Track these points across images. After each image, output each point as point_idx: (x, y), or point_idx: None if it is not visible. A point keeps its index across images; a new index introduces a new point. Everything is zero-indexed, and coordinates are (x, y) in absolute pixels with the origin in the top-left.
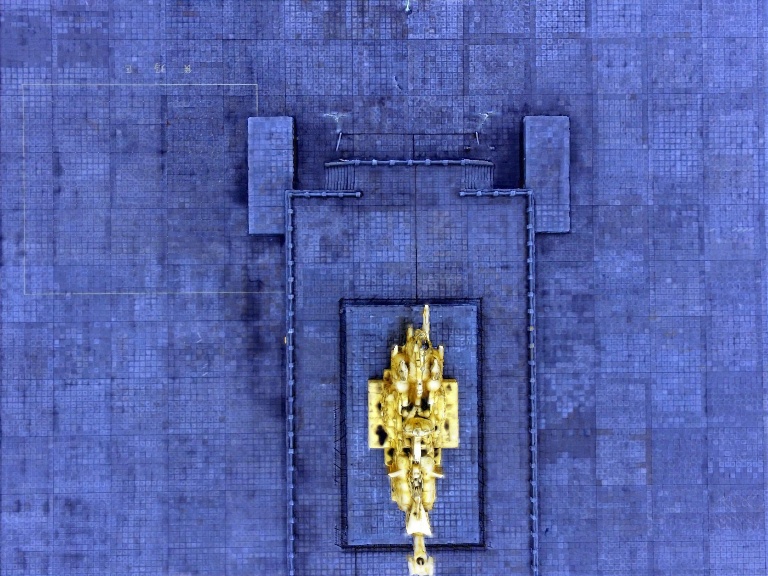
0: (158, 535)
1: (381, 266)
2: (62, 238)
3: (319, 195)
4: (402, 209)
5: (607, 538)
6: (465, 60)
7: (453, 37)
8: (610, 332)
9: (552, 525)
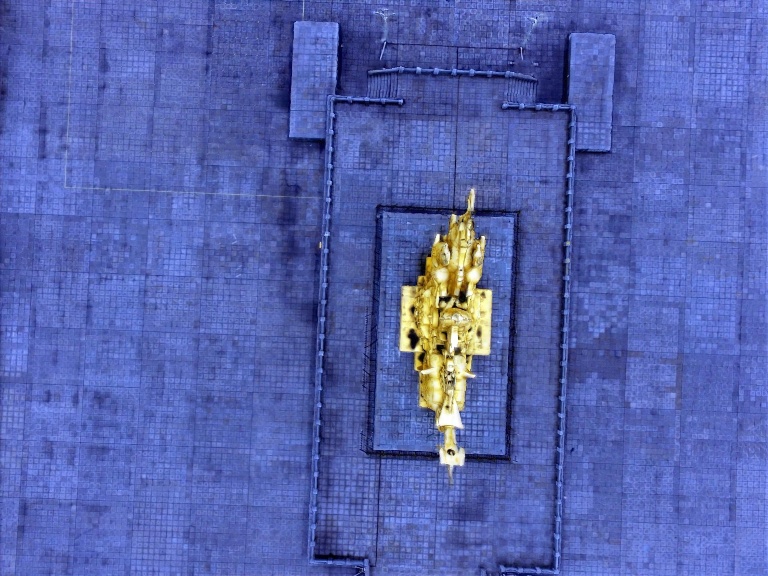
0: (184, 433)
1: (420, 175)
2: (104, 133)
3: (362, 100)
4: (443, 119)
5: (633, 461)
6: None
7: None
8: (646, 254)
9: (578, 445)
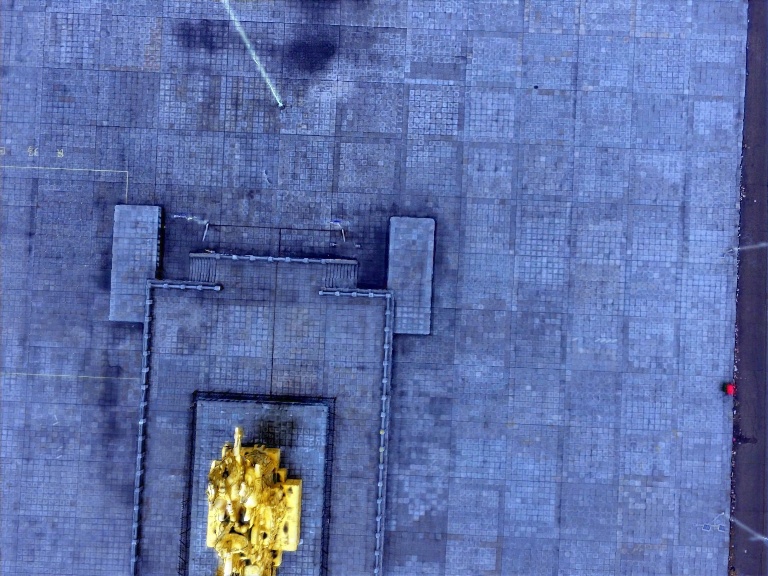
0: None
1: (237, 360)
2: None
3: (178, 287)
4: (261, 304)
5: None
6: (336, 157)
7: (325, 134)
8: (466, 437)
9: None
